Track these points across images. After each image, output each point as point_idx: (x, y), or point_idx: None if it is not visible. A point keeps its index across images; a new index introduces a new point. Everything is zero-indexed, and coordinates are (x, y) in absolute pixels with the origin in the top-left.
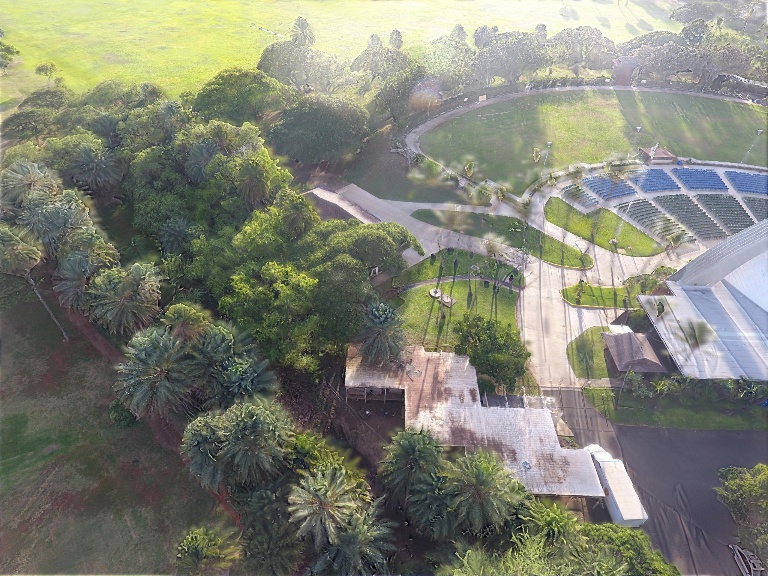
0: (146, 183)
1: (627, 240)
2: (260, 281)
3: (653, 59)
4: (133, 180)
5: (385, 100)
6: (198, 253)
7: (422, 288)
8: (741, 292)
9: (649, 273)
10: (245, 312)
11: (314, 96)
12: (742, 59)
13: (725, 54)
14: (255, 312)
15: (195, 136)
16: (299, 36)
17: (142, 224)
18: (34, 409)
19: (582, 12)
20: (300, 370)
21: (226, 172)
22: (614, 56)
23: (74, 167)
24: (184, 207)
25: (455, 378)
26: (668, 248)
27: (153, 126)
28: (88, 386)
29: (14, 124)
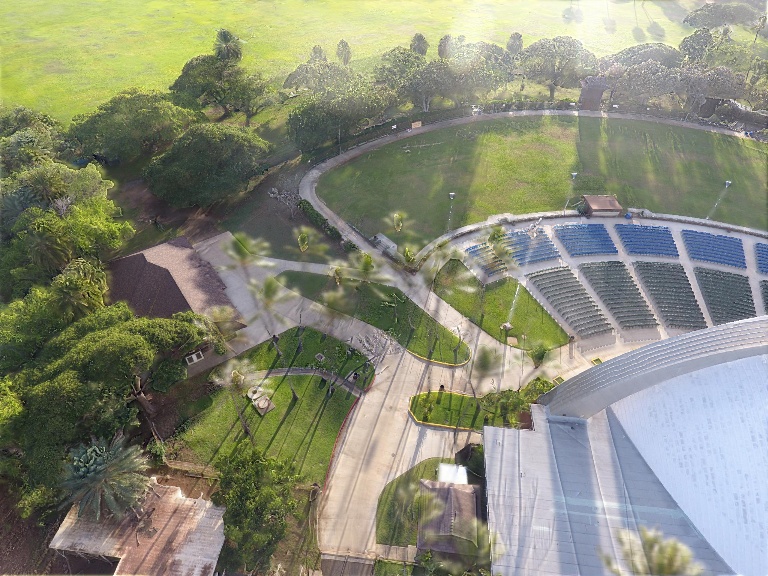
0: None
1: (524, 325)
2: None
3: (626, 80)
4: None
5: None
6: None
7: None
8: (625, 430)
9: (535, 376)
10: None
11: (202, 126)
12: (733, 83)
13: (712, 77)
14: None
15: (19, 182)
16: (223, 50)
17: None
18: None
19: (589, 13)
20: None
21: None
22: (592, 72)
23: None
24: None
25: (194, 544)
26: (573, 340)
27: (4, 162)
28: None
29: None
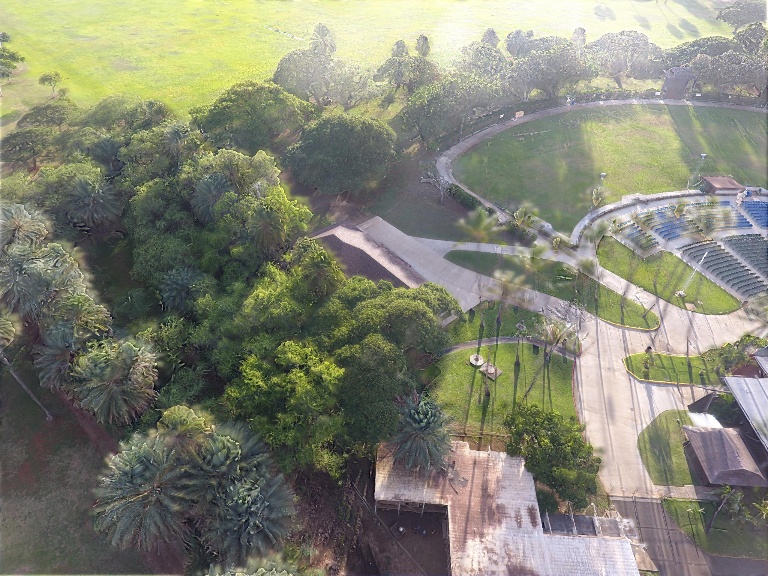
0: (147, 222)
1: (696, 292)
2: (274, 365)
3: (711, 70)
4: (134, 216)
5: (413, 118)
6: (202, 317)
7: (460, 353)
8: None
9: (726, 337)
10: (255, 407)
11: (335, 116)
12: None
13: None
14: (267, 407)
15: (203, 168)
16: (319, 44)
17: (141, 274)
18: (6, 514)
19: (618, 11)
20: (320, 468)
21: (237, 212)
22: (662, 64)
23: (68, 202)
24: (189, 253)
25: (509, 490)
26: (746, 304)
27: (158, 152)
28: (71, 483)
29: (10, 145)
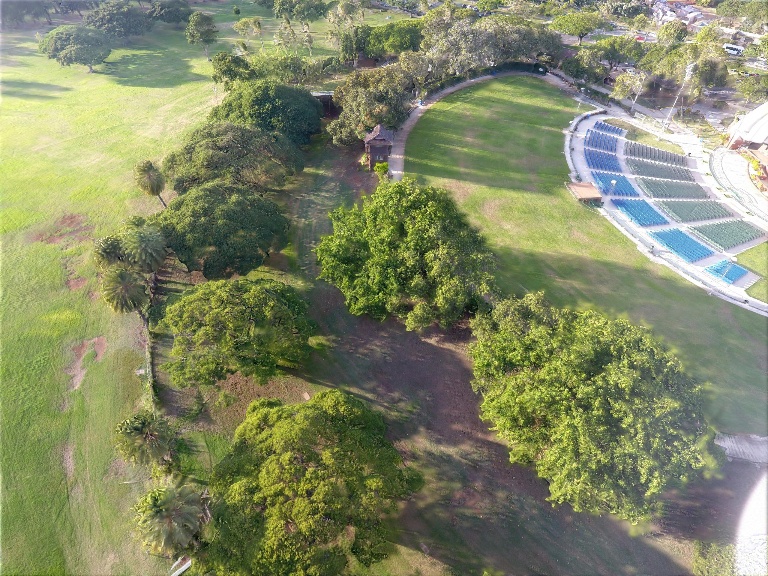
0: None
1: None
2: None
3: None
4: None
5: None
6: None
7: None
8: None
9: None
10: None
11: None
12: None
13: None
14: None
15: None
16: None
17: None
18: None
19: None
20: None
21: None
22: None
23: None
24: None
25: None
26: None
27: None
28: None
29: None
